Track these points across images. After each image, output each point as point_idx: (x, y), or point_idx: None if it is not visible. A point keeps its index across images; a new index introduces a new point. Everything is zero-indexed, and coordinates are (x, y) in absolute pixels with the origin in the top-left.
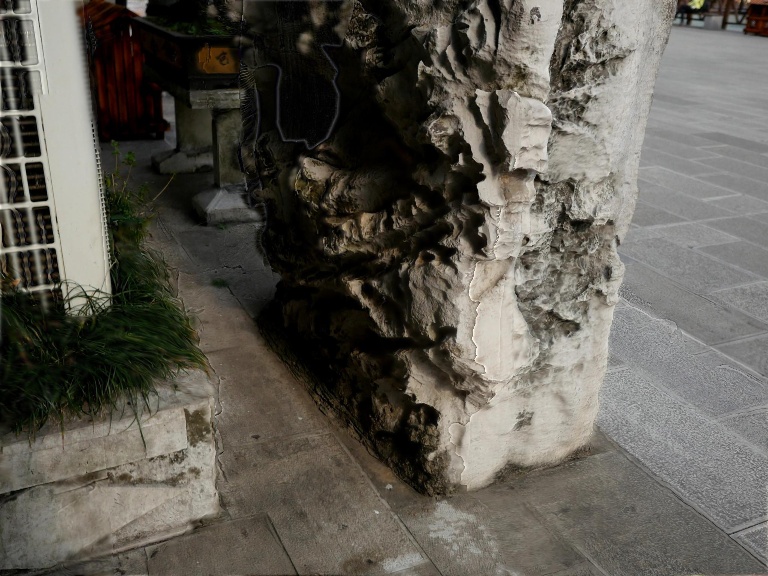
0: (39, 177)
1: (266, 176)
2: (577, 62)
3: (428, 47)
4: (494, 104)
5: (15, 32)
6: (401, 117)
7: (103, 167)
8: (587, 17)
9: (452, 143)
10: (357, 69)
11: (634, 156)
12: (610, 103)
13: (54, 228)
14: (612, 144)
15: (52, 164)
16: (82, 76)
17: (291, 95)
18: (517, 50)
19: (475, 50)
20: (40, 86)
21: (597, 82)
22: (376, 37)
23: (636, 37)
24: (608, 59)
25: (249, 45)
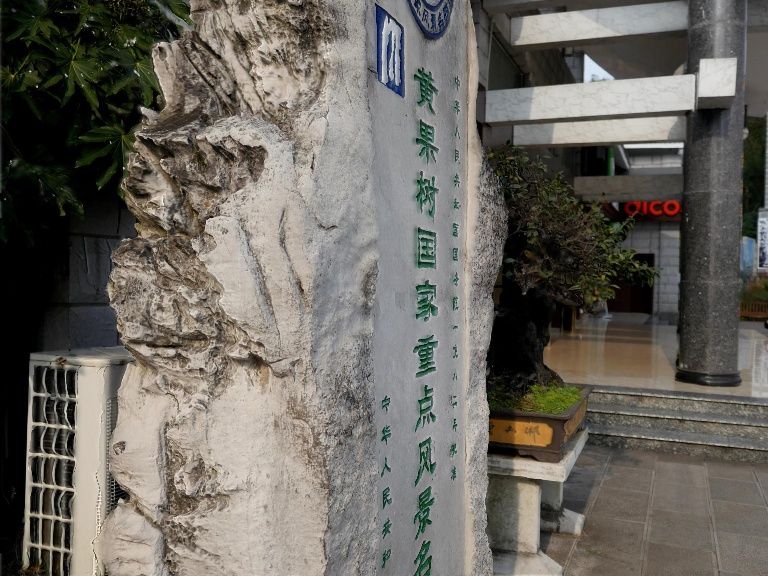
0: (66, 502)
1: None
2: (181, 492)
3: None
4: None
5: (67, 409)
6: None
7: (105, 504)
8: (182, 454)
9: None
10: None
11: None
12: (224, 537)
13: (71, 540)
14: None
15: (77, 495)
16: (93, 440)
17: None
18: None
19: None
20: (73, 443)
21: (202, 514)
22: None
23: (250, 478)
24: (214, 494)
25: None
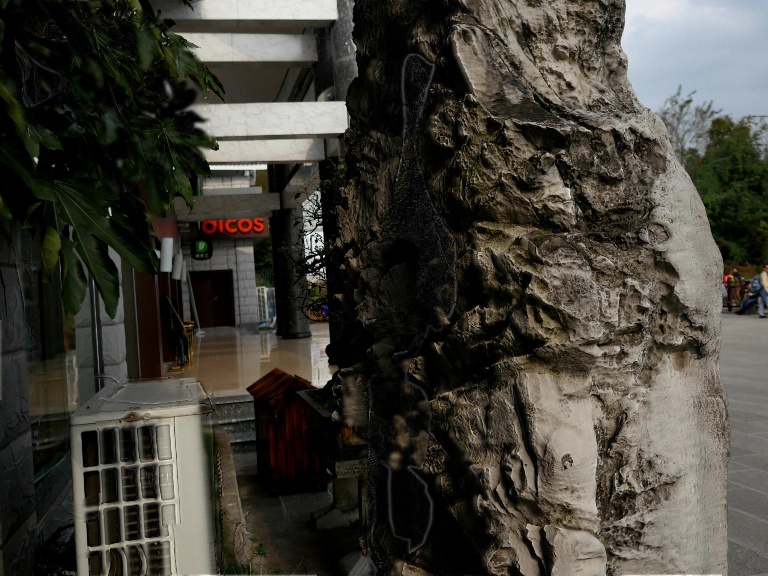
0: None
1: (381, 569)
2: (623, 493)
3: (484, 483)
4: (544, 539)
5: (158, 475)
6: (474, 539)
7: None
8: (624, 453)
9: (513, 573)
10: (437, 489)
11: (718, 568)
12: (669, 525)
13: None
14: (685, 562)
15: None
16: (208, 506)
17: None
18: (556, 491)
19: (519, 491)
20: (174, 517)
21: (649, 508)
22: (445, 468)
23: (684, 461)
24: (656, 486)
25: (376, 434)
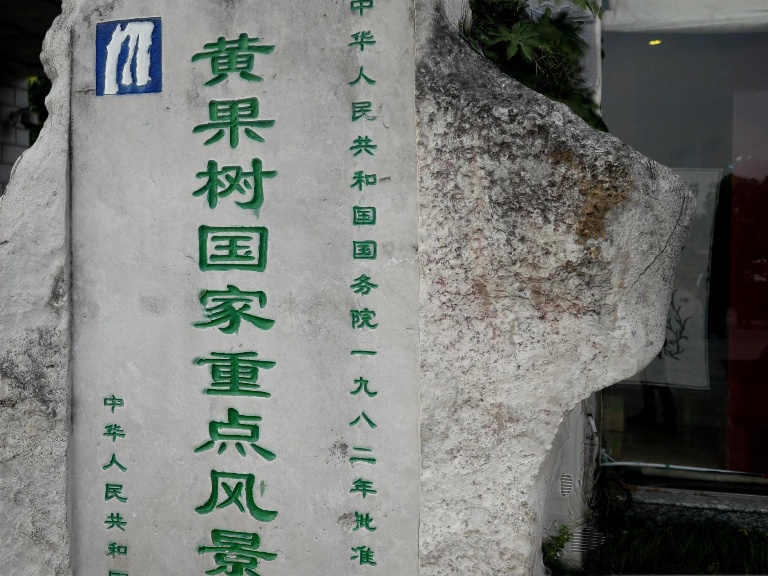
0: None
1: None
2: None
3: None
4: None
5: None
6: None
7: None
8: None
9: None
10: None
11: None
12: None
13: None
14: None
15: None
16: None
17: (536, 569)
18: None
19: None
20: None
21: None
22: None
23: None
24: None
25: None
